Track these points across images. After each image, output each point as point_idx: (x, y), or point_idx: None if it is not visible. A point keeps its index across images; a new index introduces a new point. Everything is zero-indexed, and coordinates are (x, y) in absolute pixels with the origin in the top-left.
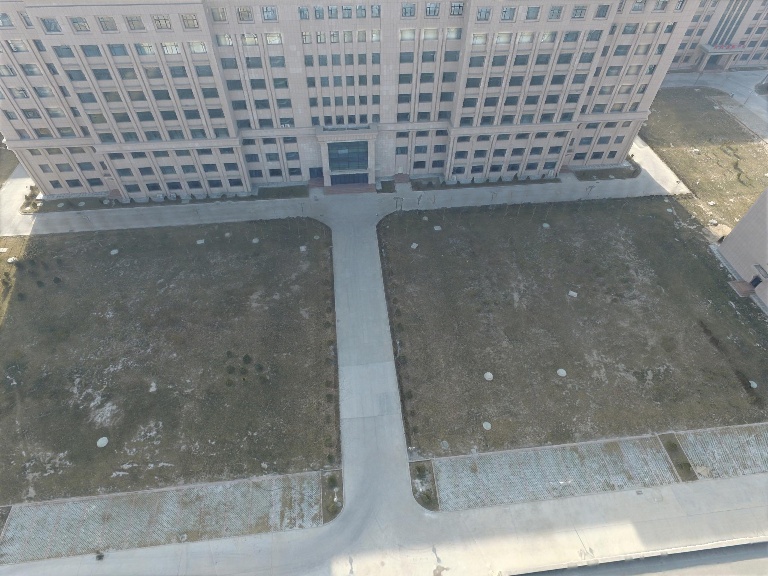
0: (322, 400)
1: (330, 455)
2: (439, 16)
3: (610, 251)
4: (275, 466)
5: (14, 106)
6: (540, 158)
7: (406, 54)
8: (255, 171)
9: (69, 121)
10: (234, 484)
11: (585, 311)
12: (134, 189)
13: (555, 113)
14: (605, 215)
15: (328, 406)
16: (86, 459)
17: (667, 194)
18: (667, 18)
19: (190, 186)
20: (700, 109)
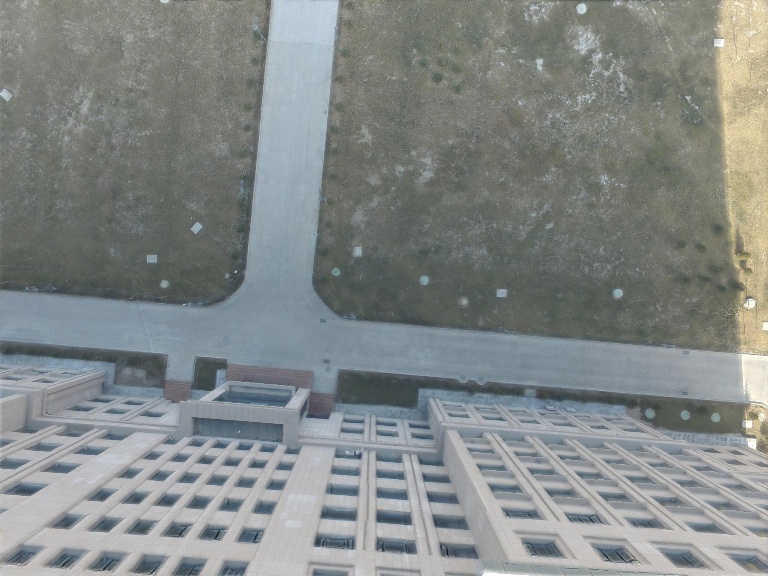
0: (357, 6)
1: None
2: None
3: None
4: None
5: None
6: None
7: None
8: None
9: None
10: None
11: (4, 65)
12: None
13: None
14: None
15: None
16: None
17: None
18: None
19: None
20: None
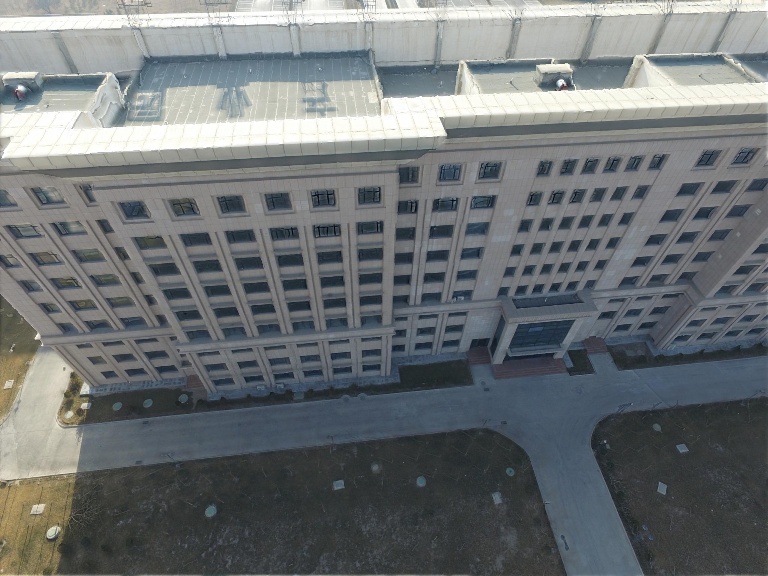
0: None
1: None
2: (749, 164)
3: None
4: None
5: (57, 299)
6: None
7: (672, 211)
8: (395, 345)
9: (140, 311)
10: None
11: None
12: (224, 380)
13: None
14: None
15: None
16: None
17: None
18: None
19: (305, 374)
20: None
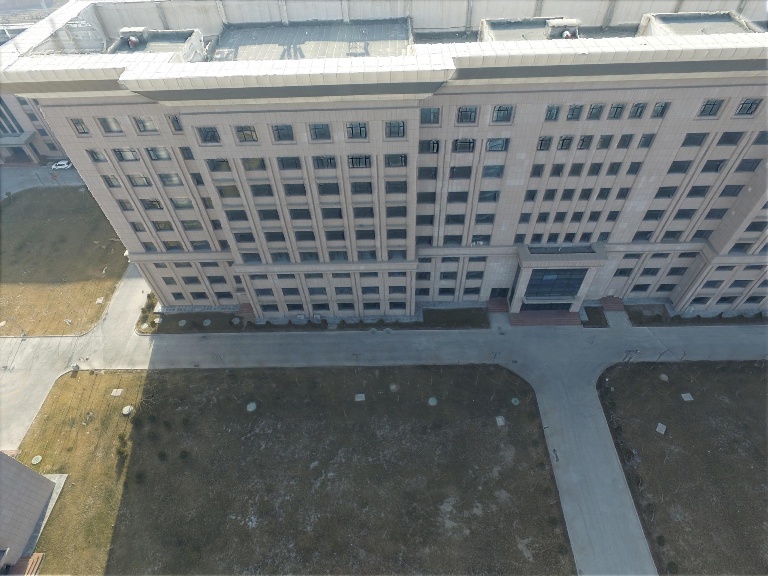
0: None
1: None
2: (753, 115)
3: None
4: None
5: (144, 218)
6: None
7: (679, 162)
8: (421, 289)
9: (206, 234)
10: None
11: None
12: (270, 307)
13: None
14: None
15: None
16: None
17: None
18: None
19: (339, 307)
20: None
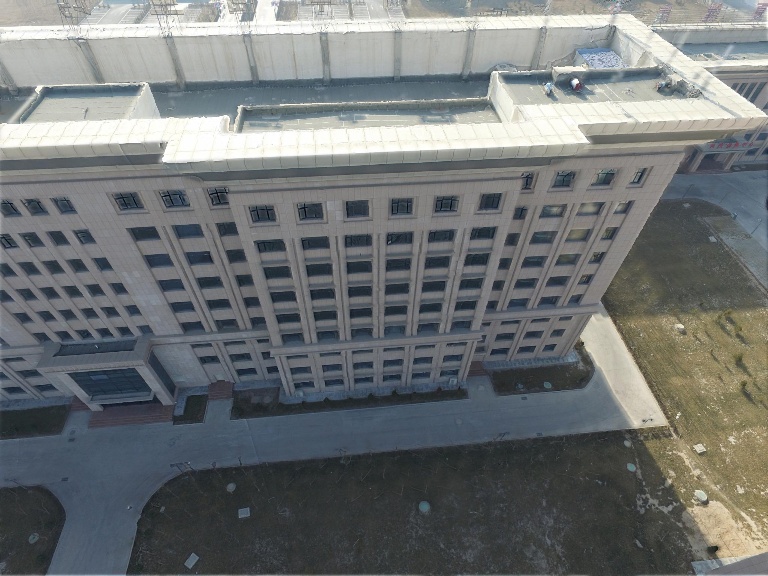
0: None
1: None
2: (192, 207)
3: (522, 575)
4: None
5: None
6: (431, 367)
7: (157, 256)
8: None
9: None
10: None
11: None
12: None
13: (440, 323)
14: (525, 479)
15: None
16: None
17: (630, 427)
18: (616, 196)
19: None
20: (689, 241)
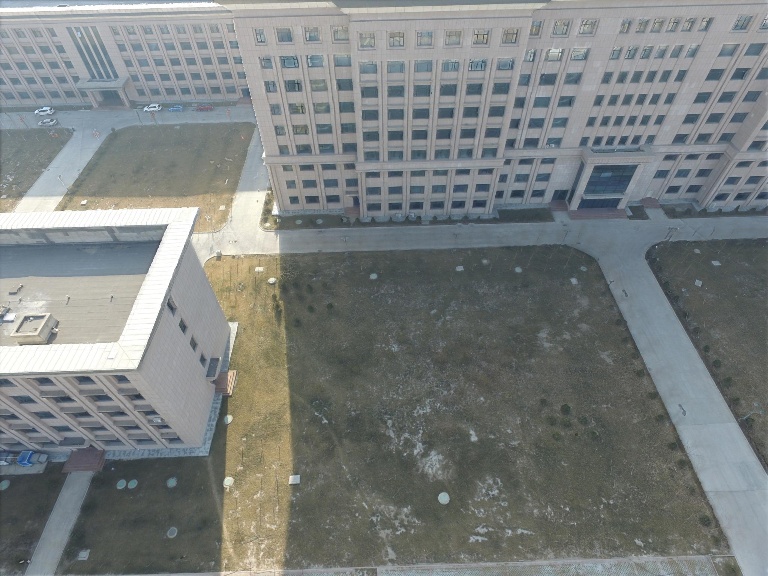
0: (673, 466)
1: (715, 537)
2: None
3: None
4: (652, 545)
5: (287, 122)
6: None
7: (715, 71)
8: (496, 192)
9: (334, 138)
10: (614, 564)
11: None
12: (373, 208)
13: None
14: None
15: (683, 474)
16: (434, 517)
17: None
18: None
19: (431, 206)
20: None
